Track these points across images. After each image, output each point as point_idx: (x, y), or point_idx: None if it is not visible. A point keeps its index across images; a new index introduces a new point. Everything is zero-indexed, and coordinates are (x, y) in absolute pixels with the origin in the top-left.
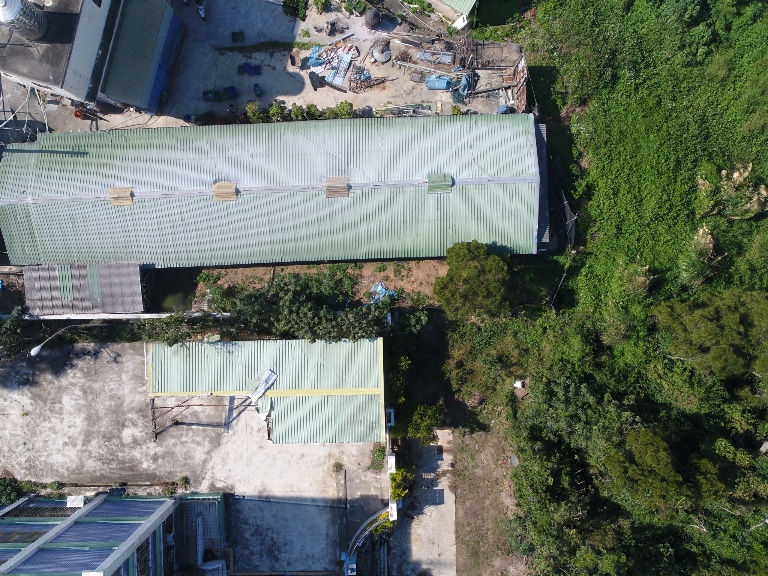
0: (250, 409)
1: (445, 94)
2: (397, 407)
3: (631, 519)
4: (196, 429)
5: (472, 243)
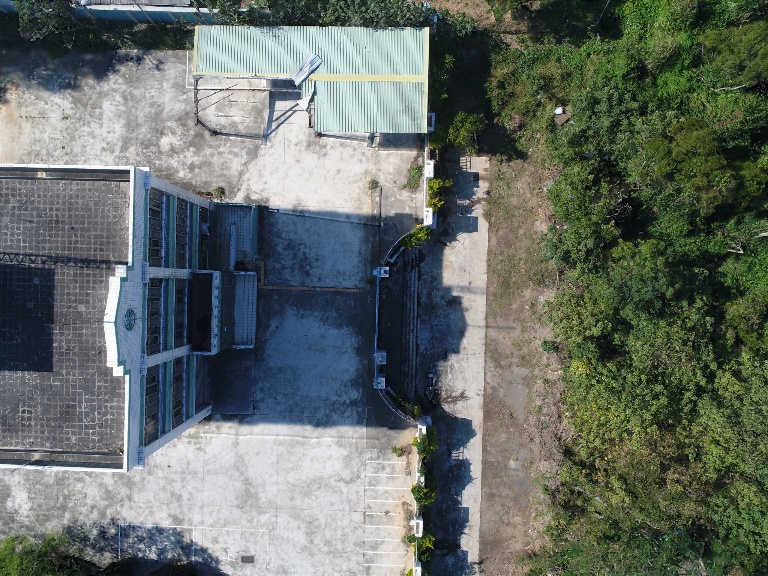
0: (289, 122)
1: None
2: (438, 116)
3: (665, 256)
4: (234, 140)
5: None
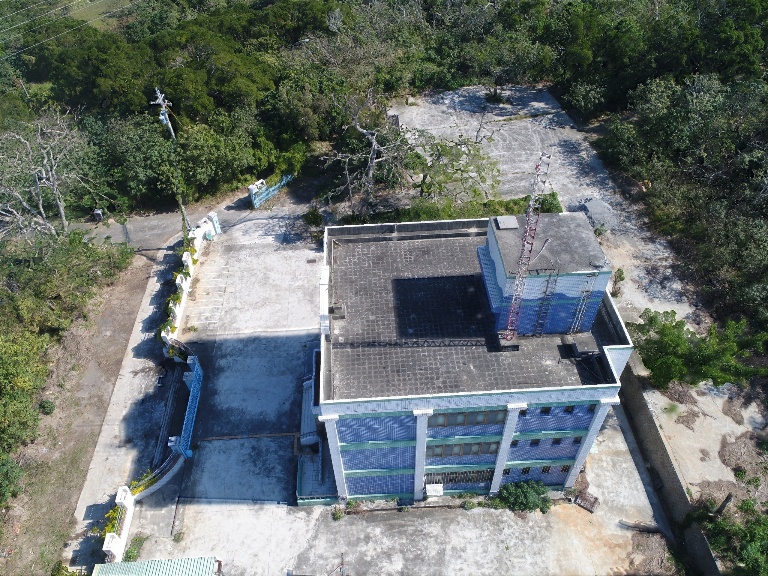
0: None
1: None
2: None
3: None
4: (323, 573)
5: None
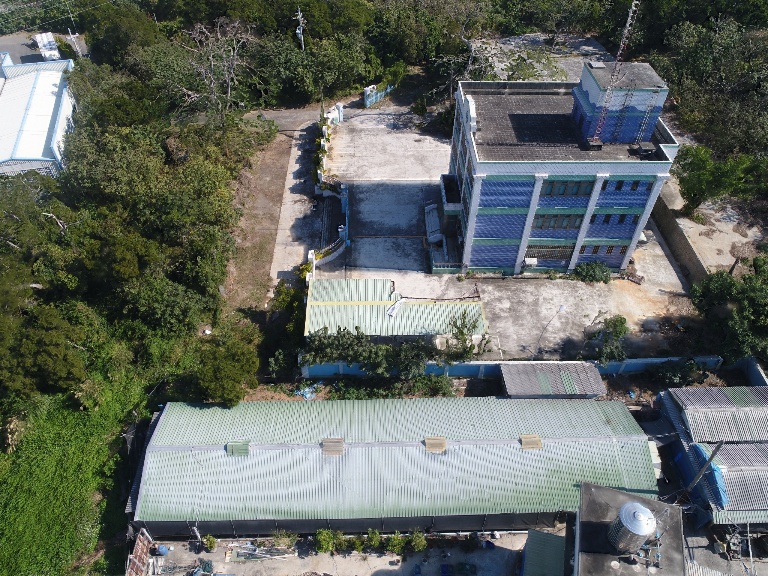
0: None
1: (219, 571)
2: None
3: None
4: None
5: (220, 395)
